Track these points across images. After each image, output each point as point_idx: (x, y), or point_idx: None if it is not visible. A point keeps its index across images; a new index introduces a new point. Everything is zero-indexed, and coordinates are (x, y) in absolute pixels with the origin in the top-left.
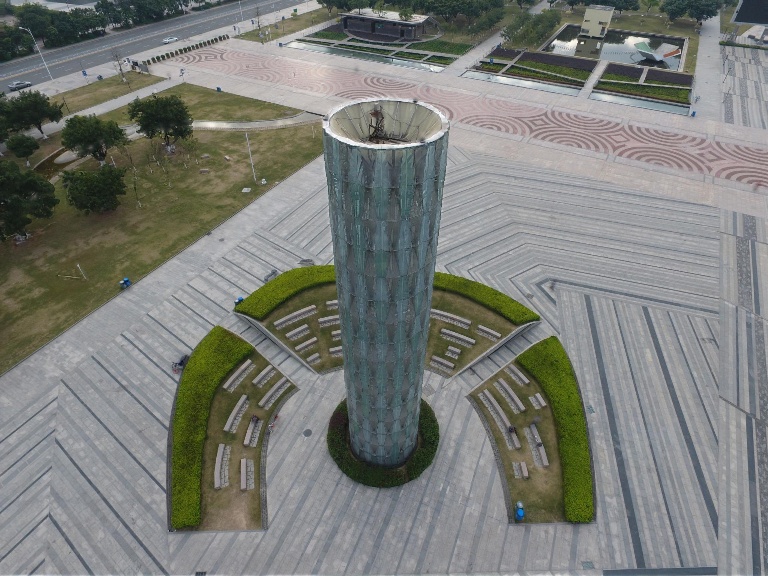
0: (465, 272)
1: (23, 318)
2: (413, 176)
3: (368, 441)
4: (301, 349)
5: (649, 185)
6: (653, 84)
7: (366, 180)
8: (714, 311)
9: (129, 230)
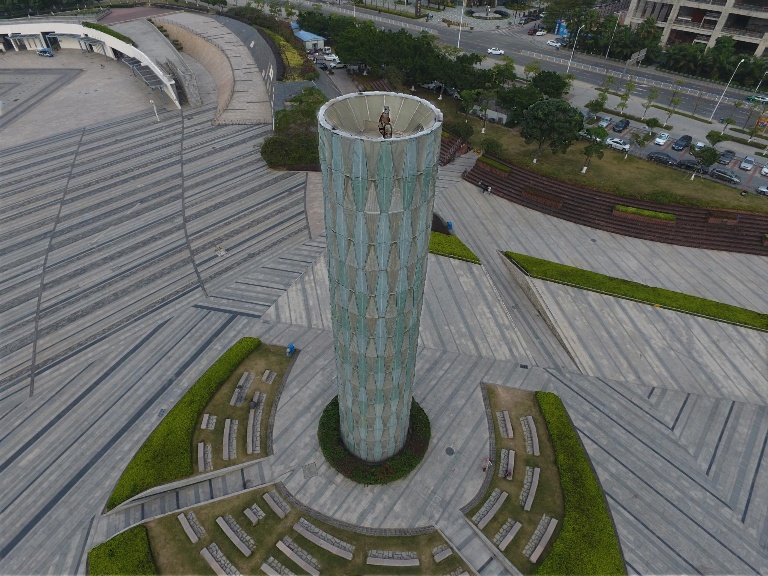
0: None
1: None
2: None
3: None
4: (461, 575)
5: None
6: None
7: None
8: None
9: None
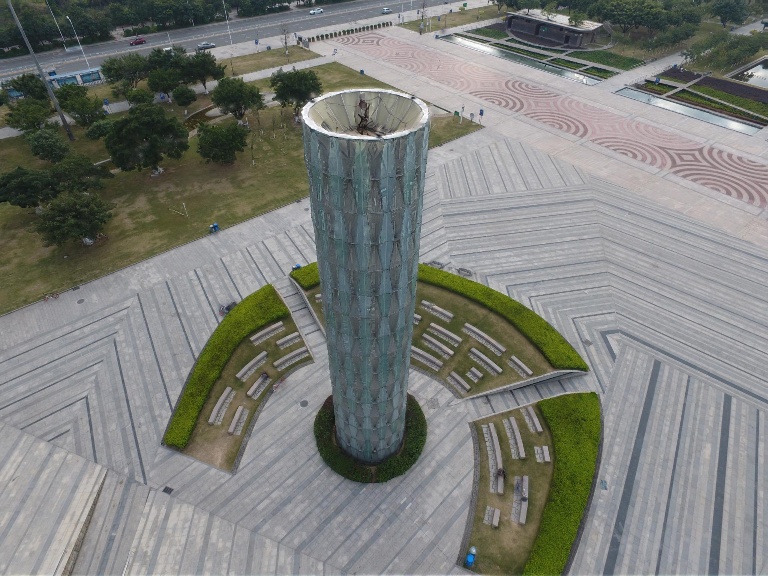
0: (525, 298)
1: (132, 236)
2: (368, 170)
3: (343, 429)
4: None
5: None
6: None
7: (324, 166)
8: None
9: (236, 183)
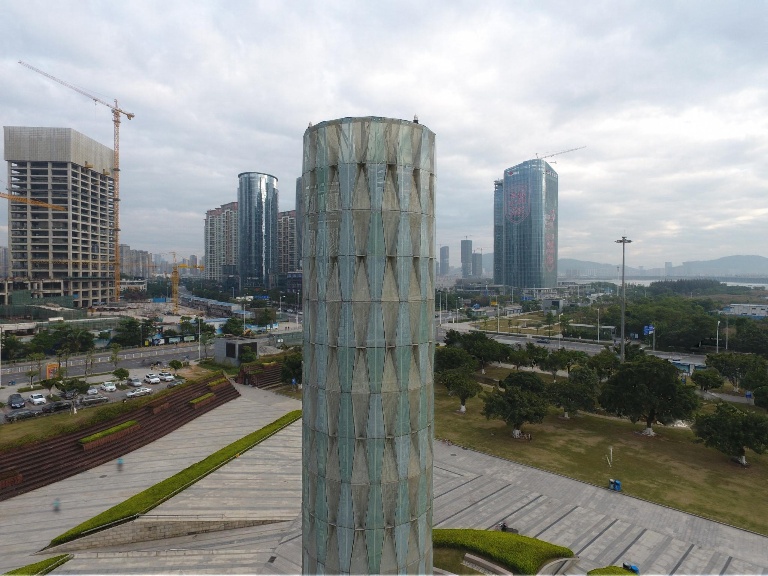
0: None
1: (546, 450)
2: None
3: None
4: None
5: None
6: None
7: None
8: None
9: (715, 480)
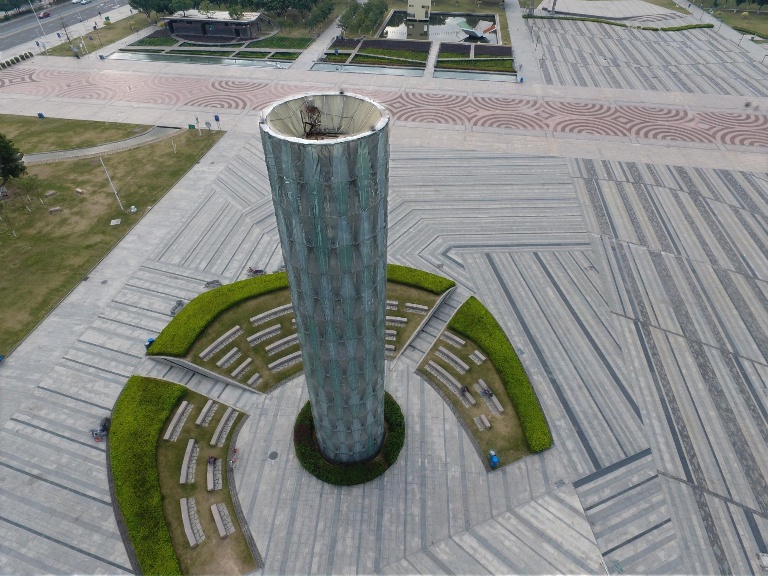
0: None
1: None
2: (369, 165)
3: (343, 442)
4: (238, 374)
5: (506, 147)
6: (482, 58)
7: (324, 177)
8: (586, 243)
9: None
